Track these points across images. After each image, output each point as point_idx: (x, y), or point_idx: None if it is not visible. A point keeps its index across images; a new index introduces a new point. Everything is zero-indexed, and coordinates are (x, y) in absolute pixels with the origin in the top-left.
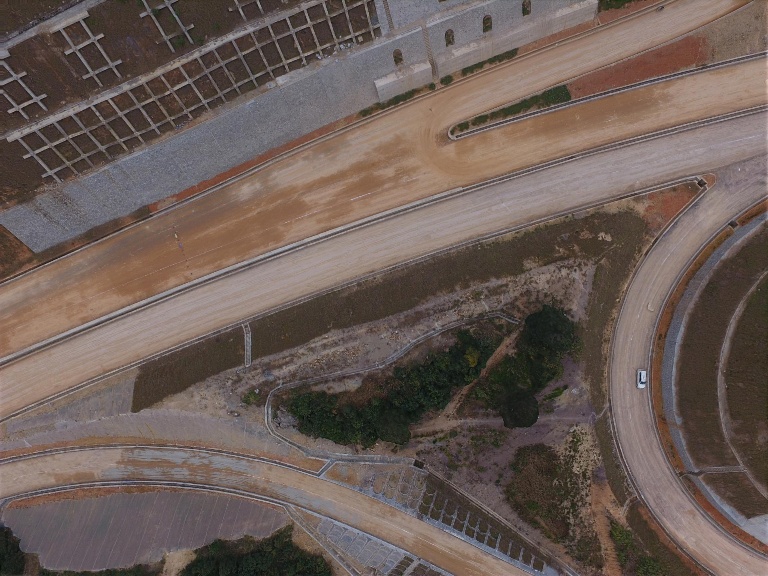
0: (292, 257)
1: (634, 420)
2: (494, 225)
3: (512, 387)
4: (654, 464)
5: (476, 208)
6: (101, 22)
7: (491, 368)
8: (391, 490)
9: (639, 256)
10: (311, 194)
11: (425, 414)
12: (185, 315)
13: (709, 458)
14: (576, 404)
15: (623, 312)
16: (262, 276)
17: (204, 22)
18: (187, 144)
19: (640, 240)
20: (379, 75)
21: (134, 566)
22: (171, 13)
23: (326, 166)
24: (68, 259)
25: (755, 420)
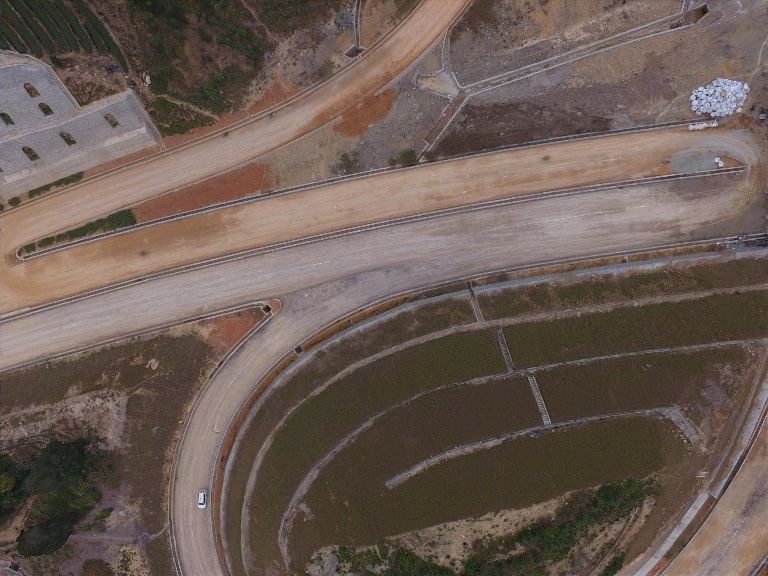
0: None
1: (196, 538)
2: (65, 344)
3: (63, 507)
4: None
5: (47, 327)
6: None
7: None
8: None
9: (203, 379)
10: None
11: None
12: None
13: None
14: (123, 526)
15: (188, 433)
16: None
17: None
18: None
19: (204, 364)
20: None
21: None
22: None
23: None
24: None
25: (262, 556)
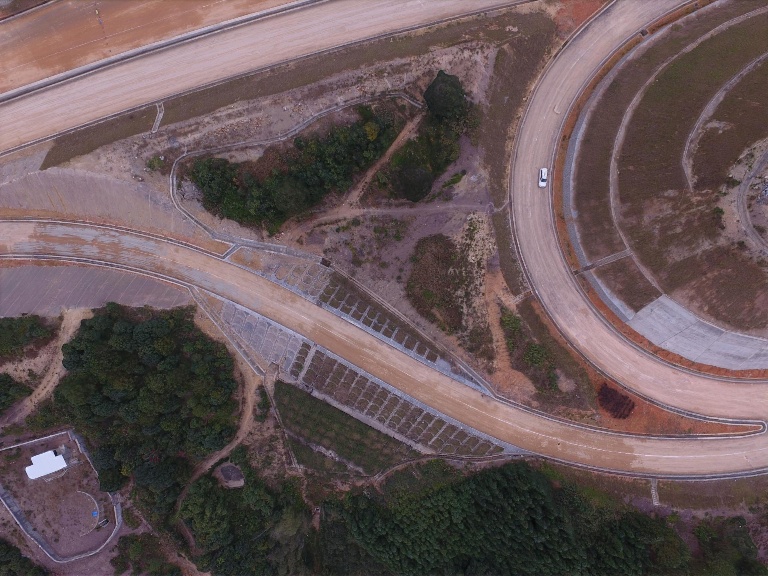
0: (209, 41)
1: (534, 218)
2: (408, 21)
3: None
4: (551, 262)
5: (391, 3)
6: None
7: (393, 153)
8: (294, 279)
9: (548, 58)
10: None
11: (328, 199)
12: (102, 93)
13: (600, 248)
14: (474, 191)
15: (529, 112)
16: (179, 58)
17: None
18: None
19: (550, 42)
20: None
21: (31, 316)
22: None
23: None
24: None
25: (642, 200)
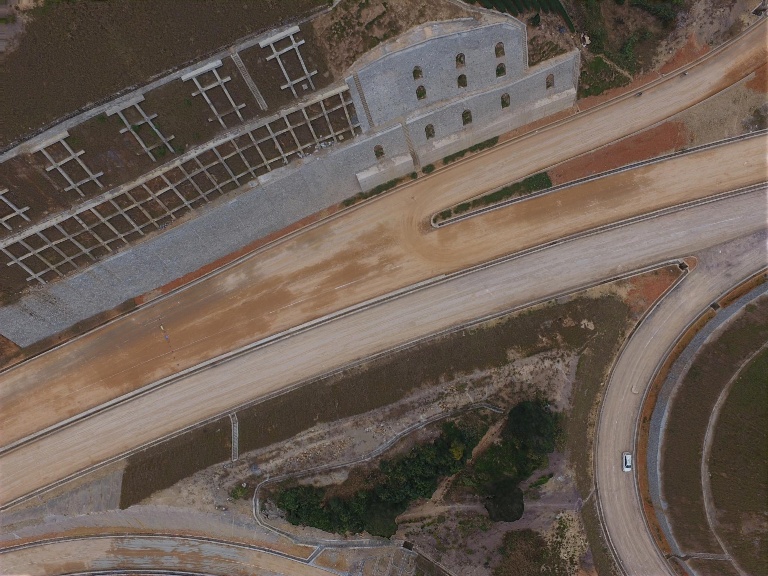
0: (278, 346)
1: (620, 503)
2: (478, 311)
3: (498, 475)
4: (641, 547)
5: (460, 294)
6: (81, 140)
7: (477, 456)
8: (380, 575)
9: (622, 340)
10: (296, 284)
11: (412, 501)
12: (172, 405)
13: (695, 544)
14: (562, 491)
15: (608, 395)
16: (248, 365)
17: (184, 132)
18: (171, 242)
19: (623, 324)
20: (361, 168)
21: None
22: (151, 127)
23: (310, 256)
24: (55, 352)
25: (739, 511)
